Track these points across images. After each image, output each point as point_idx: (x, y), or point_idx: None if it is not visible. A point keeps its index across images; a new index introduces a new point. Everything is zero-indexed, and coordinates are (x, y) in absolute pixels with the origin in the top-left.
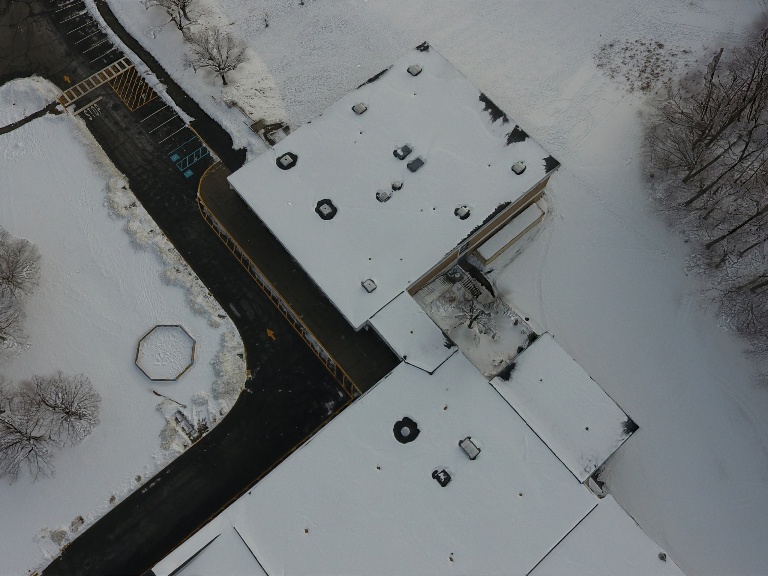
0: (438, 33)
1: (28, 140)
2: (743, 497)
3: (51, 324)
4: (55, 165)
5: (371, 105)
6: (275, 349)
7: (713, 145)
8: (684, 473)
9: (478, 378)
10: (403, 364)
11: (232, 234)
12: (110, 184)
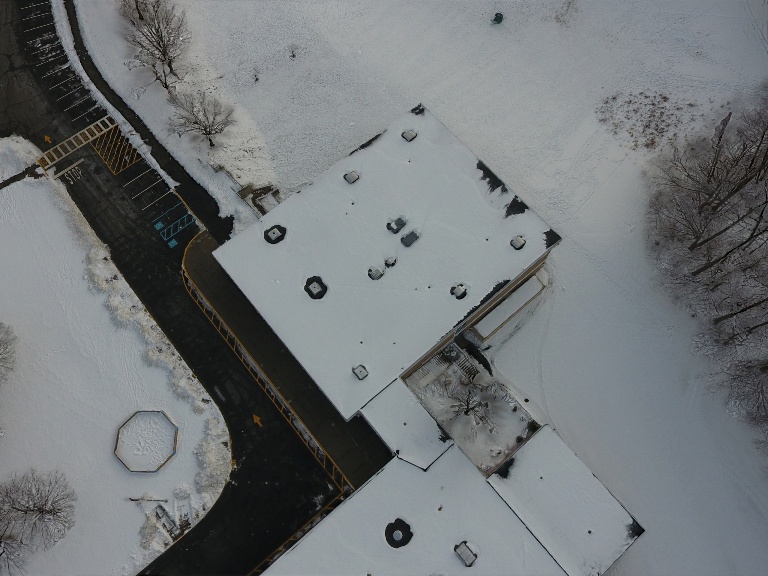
0: (434, 88)
1: (6, 206)
2: None
3: (26, 409)
4: (33, 234)
5: (363, 173)
6: (262, 437)
7: (720, 209)
8: (691, 570)
9: (475, 475)
10: (396, 459)
11: (218, 310)
12: (90, 255)
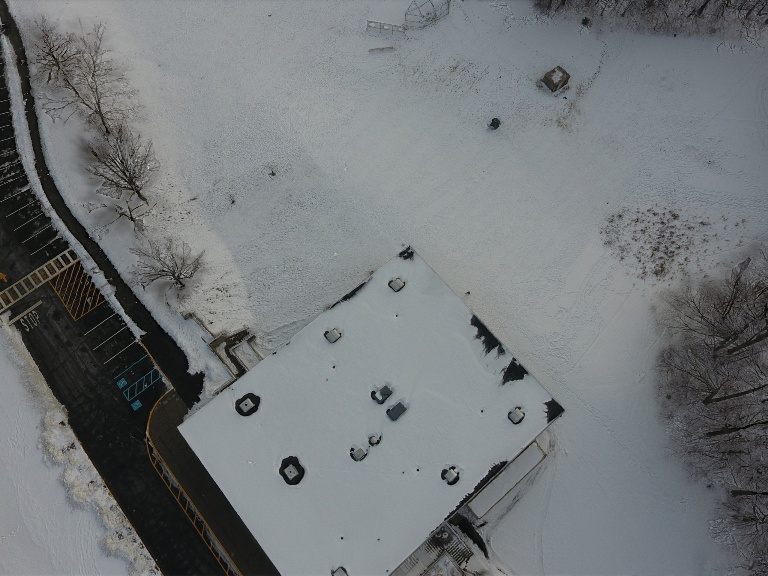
0: (426, 210)
1: None
2: None
3: None
4: None
5: (346, 330)
6: None
7: (737, 354)
8: None
9: None
10: None
11: (184, 487)
12: (46, 420)
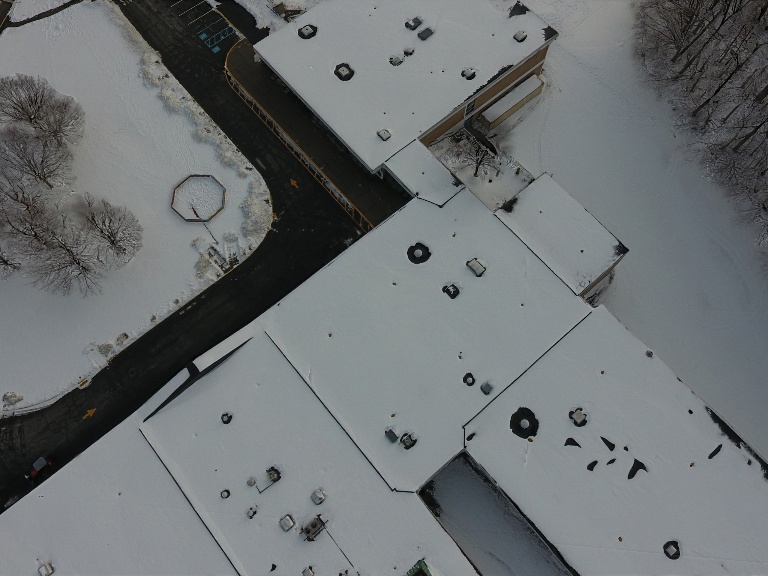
0: None
1: (67, 22)
2: (724, 324)
3: (94, 175)
4: (93, 43)
5: None
6: (298, 196)
7: (700, 30)
8: (671, 304)
9: (483, 210)
10: (416, 199)
11: (257, 100)
12: (144, 58)
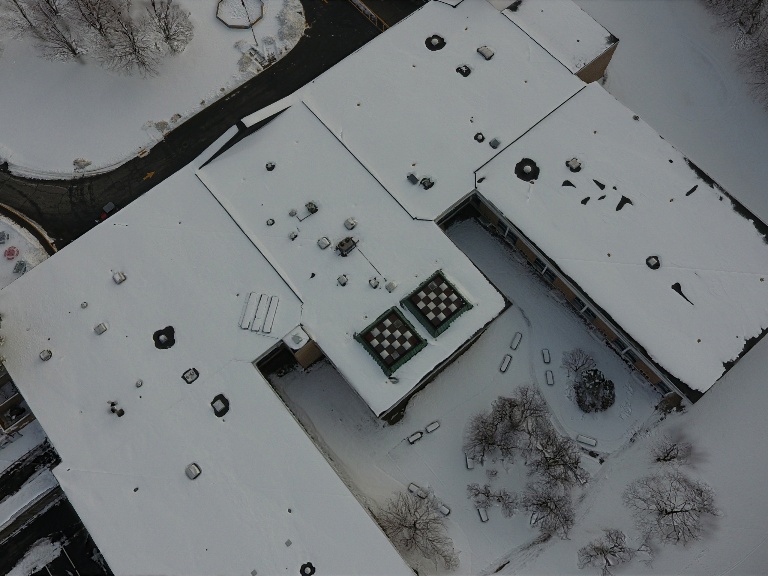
0: None
1: None
2: (704, 117)
3: None
4: None
5: None
6: (328, 9)
7: None
8: (657, 101)
9: (492, 10)
10: (432, 1)
11: None
12: None
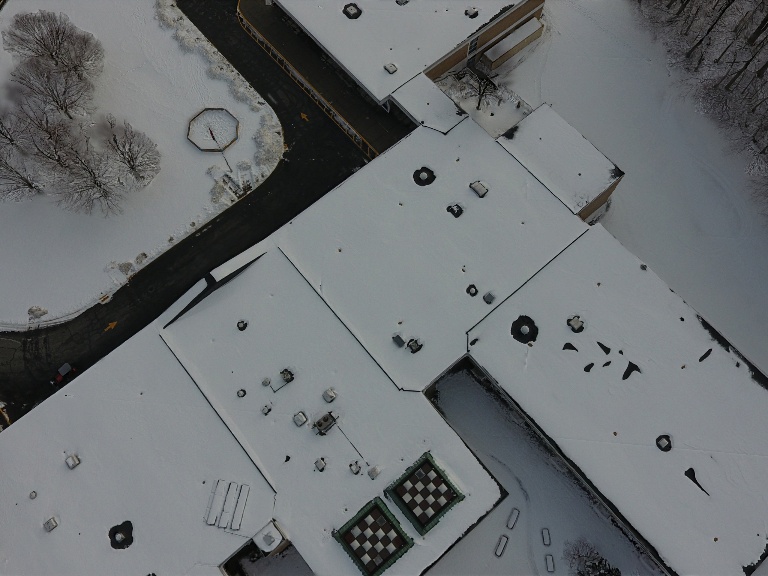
0: None
1: None
2: (716, 249)
3: (113, 108)
4: None
5: None
6: (308, 128)
7: None
8: (665, 230)
9: (486, 138)
10: (421, 127)
11: (269, 40)
12: (160, 1)
